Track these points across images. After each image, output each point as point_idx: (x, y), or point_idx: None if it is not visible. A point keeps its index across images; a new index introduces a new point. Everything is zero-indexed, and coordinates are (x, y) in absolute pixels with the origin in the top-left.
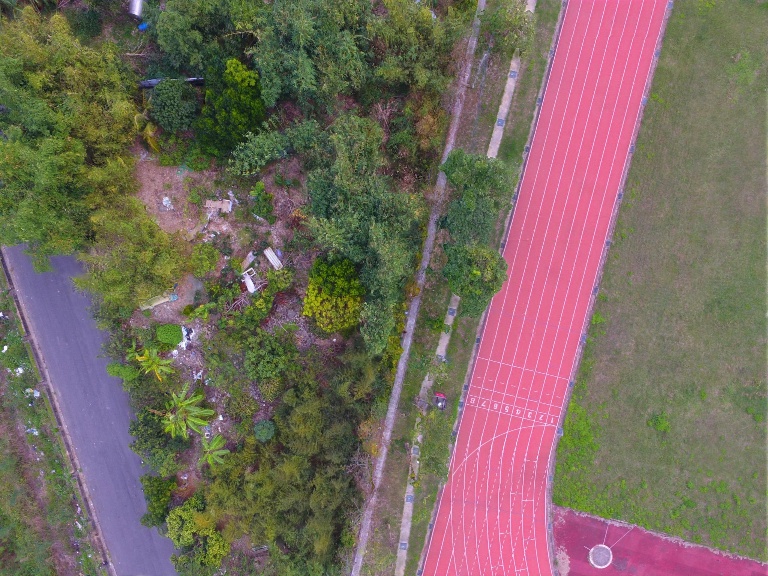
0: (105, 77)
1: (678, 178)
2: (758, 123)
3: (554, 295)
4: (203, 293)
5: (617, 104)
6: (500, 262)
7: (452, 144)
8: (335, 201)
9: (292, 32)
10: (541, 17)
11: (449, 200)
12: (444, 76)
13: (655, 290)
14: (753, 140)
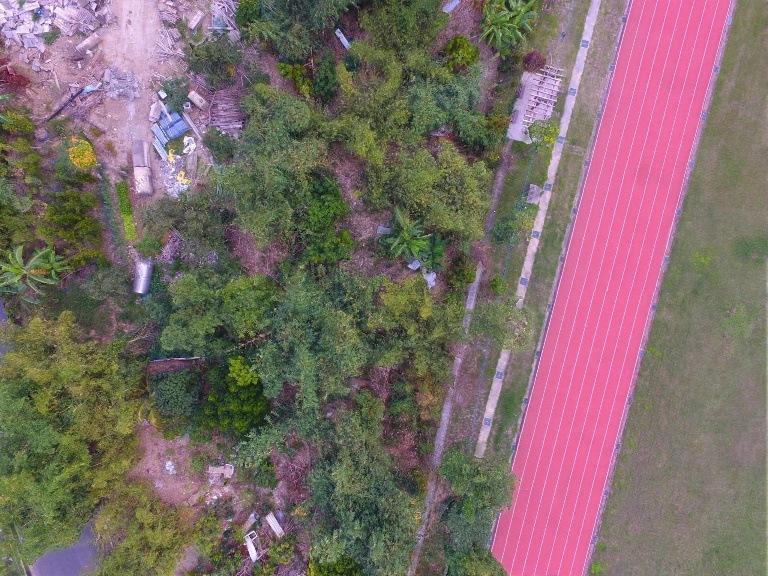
0: (110, 388)
1: (675, 429)
2: (754, 375)
3: (553, 544)
4: (205, 560)
5: (615, 356)
6: (499, 574)
7: (452, 397)
8: (336, 500)
9: (294, 350)
10: (539, 273)
11: (449, 451)
12: (444, 351)
13: (653, 539)
14: (749, 392)
